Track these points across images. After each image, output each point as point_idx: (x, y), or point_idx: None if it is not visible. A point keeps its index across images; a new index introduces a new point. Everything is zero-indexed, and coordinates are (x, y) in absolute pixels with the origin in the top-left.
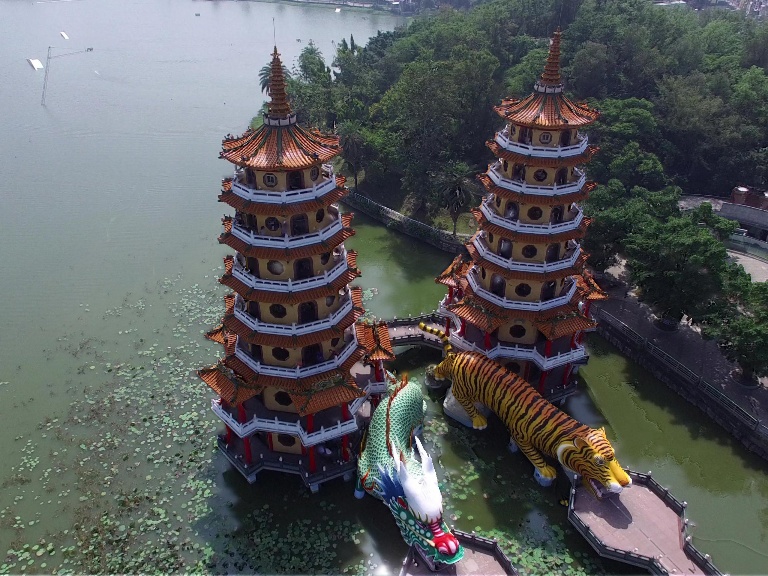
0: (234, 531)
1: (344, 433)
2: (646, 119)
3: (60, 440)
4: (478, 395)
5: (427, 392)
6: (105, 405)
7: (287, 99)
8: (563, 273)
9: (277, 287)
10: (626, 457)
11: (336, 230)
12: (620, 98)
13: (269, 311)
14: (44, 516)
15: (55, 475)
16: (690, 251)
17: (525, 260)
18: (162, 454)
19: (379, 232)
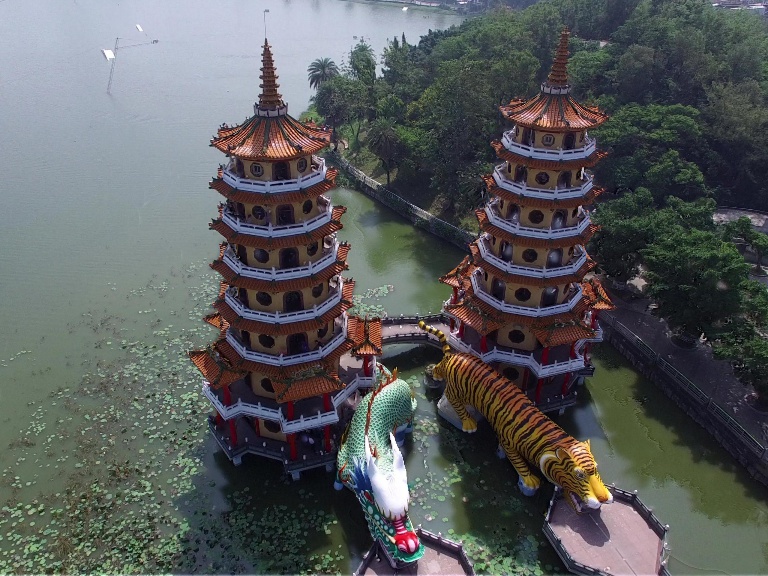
0: (212, 510)
1: (324, 424)
2: (689, 127)
3: (67, 409)
4: (468, 398)
5: (425, 391)
6: (114, 379)
7: (329, 94)
8: (563, 280)
9: (261, 275)
10: (621, 474)
11: (323, 222)
12: (666, 104)
13: (256, 298)
14: (41, 478)
15: (57, 441)
16: (707, 265)
17: (525, 264)
18: (158, 430)
19: (406, 230)
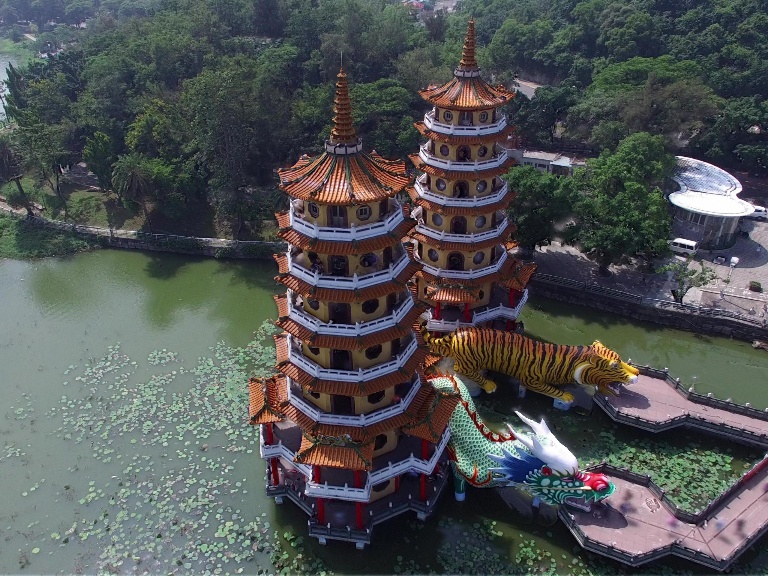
0: None
1: None
2: (405, 95)
3: None
4: (486, 362)
5: None
6: None
7: (2, 150)
8: (508, 232)
9: (382, 325)
10: None
11: None
12: (363, 82)
13: (365, 356)
14: None
15: None
16: (548, 188)
17: (480, 230)
18: None
19: (210, 266)
